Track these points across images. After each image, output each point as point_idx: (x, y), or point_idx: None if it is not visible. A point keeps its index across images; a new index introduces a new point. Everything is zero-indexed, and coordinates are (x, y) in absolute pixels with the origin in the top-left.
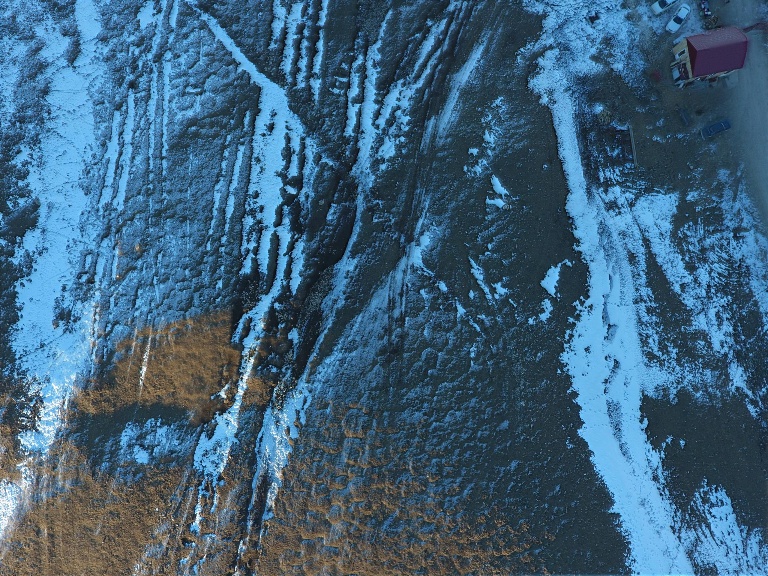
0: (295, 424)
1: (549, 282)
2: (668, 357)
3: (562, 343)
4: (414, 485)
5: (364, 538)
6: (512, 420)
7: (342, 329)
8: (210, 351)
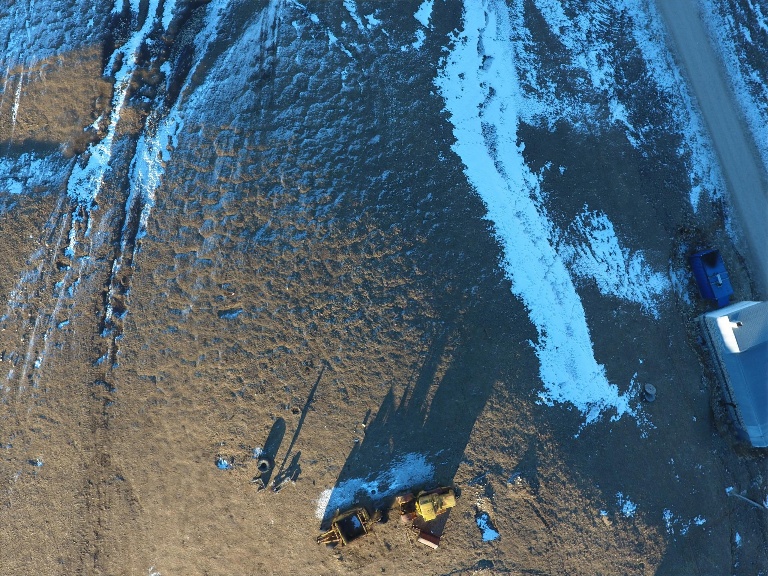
0: (167, 148)
1: (422, 14)
2: (546, 91)
3: (435, 68)
4: (285, 197)
5: (236, 249)
6: (383, 135)
7: (214, 60)
8: (82, 84)
